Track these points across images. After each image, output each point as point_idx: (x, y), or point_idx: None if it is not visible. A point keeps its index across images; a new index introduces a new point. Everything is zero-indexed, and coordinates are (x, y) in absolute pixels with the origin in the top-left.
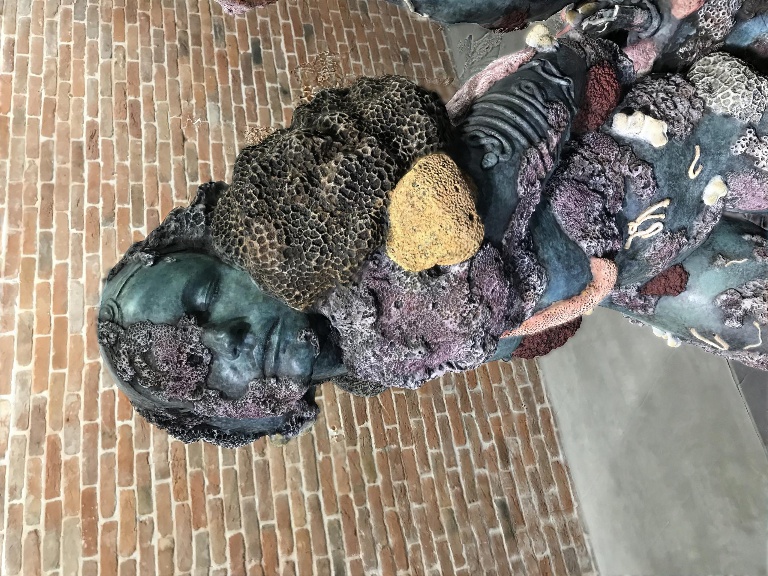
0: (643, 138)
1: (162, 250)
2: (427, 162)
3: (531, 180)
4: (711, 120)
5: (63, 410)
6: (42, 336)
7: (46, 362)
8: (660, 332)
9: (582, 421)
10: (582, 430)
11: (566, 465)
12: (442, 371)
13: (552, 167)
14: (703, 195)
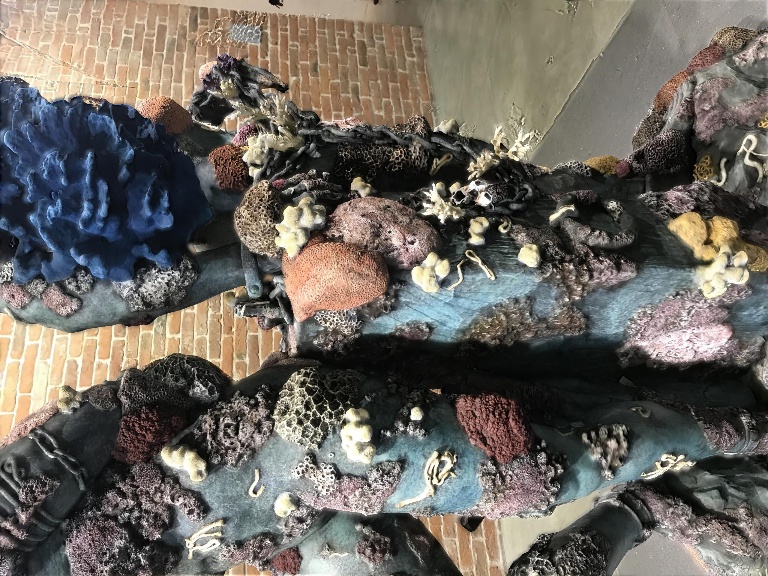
0: None
1: None
2: None
3: None
4: (275, 444)
5: None
6: (6, 414)
7: None
8: None
9: (519, 530)
10: (519, 539)
11: (505, 571)
12: None
13: (26, 536)
14: (274, 508)
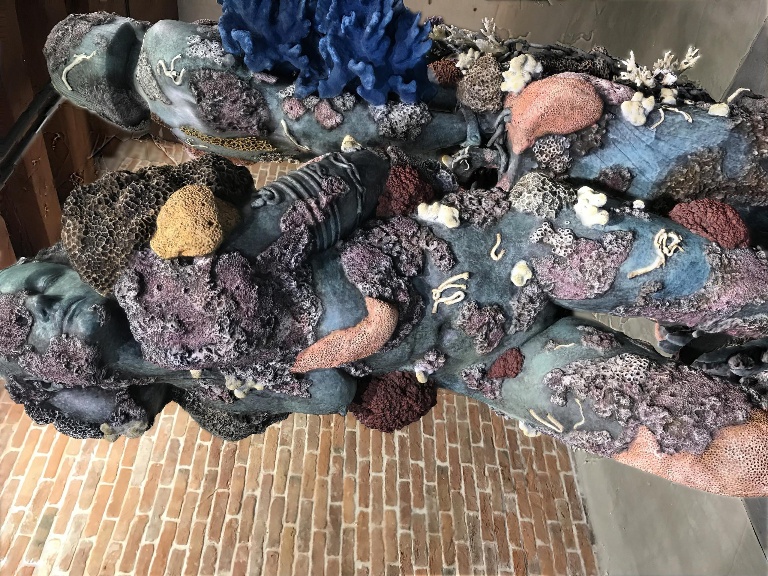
0: (441, 222)
1: None
2: (187, 187)
3: (297, 223)
4: (514, 216)
5: (104, 557)
6: (106, 484)
7: (102, 509)
8: (522, 424)
9: None
10: None
11: None
12: (201, 353)
13: (323, 219)
14: (511, 276)
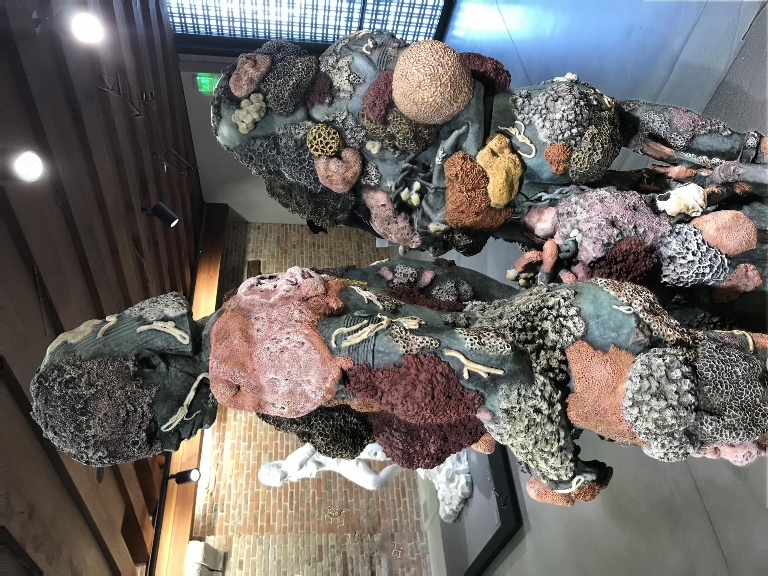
0: None
1: None
2: None
3: None
4: None
5: None
6: None
7: None
8: None
9: None
10: None
11: None
12: None
13: None
14: None
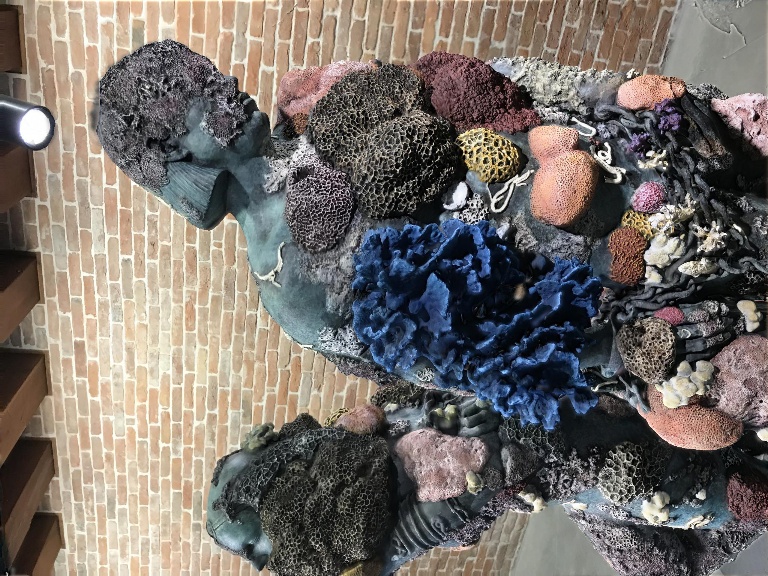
0: None
1: (237, 509)
2: None
3: None
4: (594, 492)
5: None
6: None
7: (187, 24)
8: None
9: None
10: None
11: None
12: None
13: None
14: None
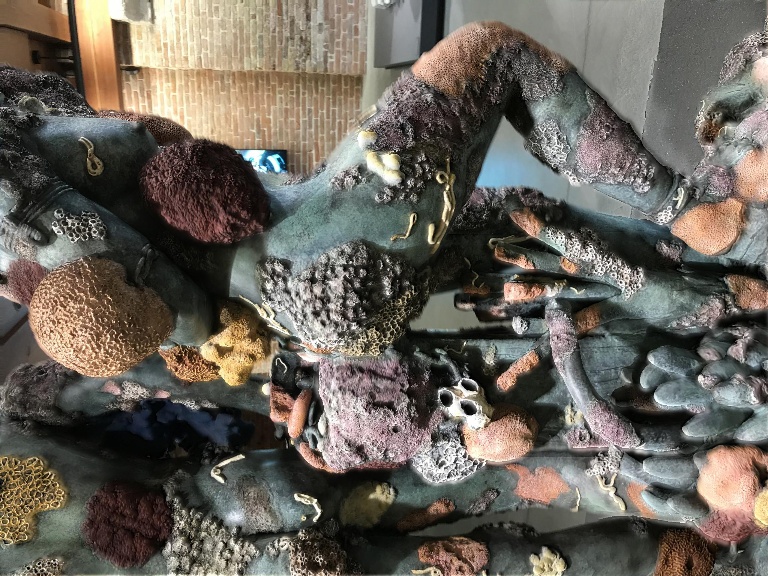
0: None
1: None
2: None
3: None
4: None
5: None
6: None
7: None
8: None
9: None
10: None
11: None
12: None
13: None
14: None
